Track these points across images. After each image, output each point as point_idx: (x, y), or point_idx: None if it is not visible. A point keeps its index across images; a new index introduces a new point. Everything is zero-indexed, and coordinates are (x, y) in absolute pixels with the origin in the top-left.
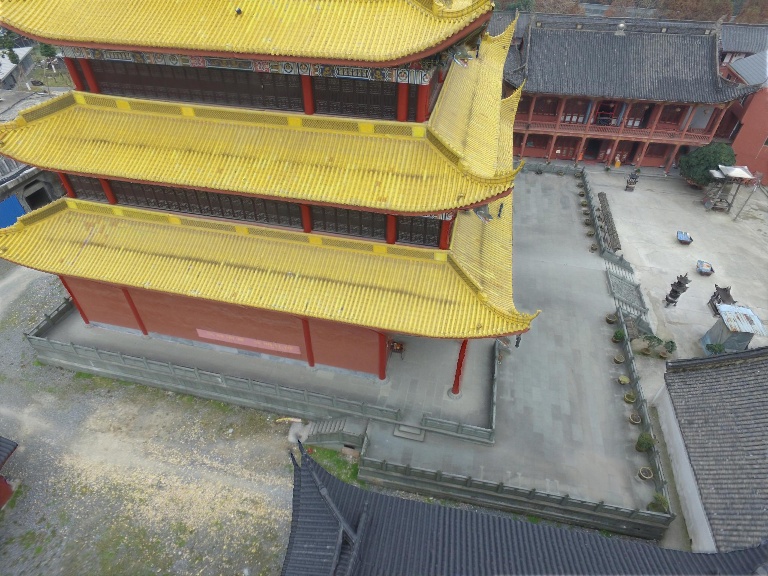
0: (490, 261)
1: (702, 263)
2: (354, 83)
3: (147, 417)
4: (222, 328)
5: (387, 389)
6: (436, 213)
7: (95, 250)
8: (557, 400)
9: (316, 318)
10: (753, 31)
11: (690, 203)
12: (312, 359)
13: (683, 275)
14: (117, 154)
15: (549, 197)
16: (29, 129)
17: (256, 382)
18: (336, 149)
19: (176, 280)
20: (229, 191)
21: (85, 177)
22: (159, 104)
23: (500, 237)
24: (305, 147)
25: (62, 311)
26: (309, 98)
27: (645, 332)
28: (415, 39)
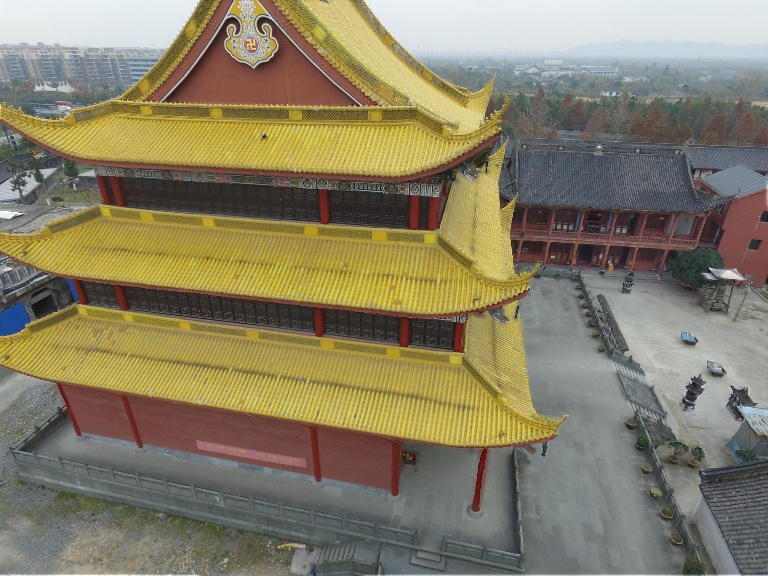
0: (504, 364)
1: (712, 364)
2: (368, 196)
3: (133, 545)
4: (224, 439)
5: (401, 507)
6: (452, 315)
7: (100, 357)
8: (587, 517)
9: (328, 426)
10: (715, 151)
11: (687, 304)
12: (319, 473)
13: (695, 376)
14: (136, 262)
15: (550, 300)
16: (53, 239)
17: (258, 501)
18: (350, 255)
19: (182, 387)
20: (245, 296)
21: (100, 284)
22: (181, 216)
23: (511, 339)
24: (320, 254)
25: (54, 422)
26: (325, 209)
27: (668, 438)
28: (427, 158)
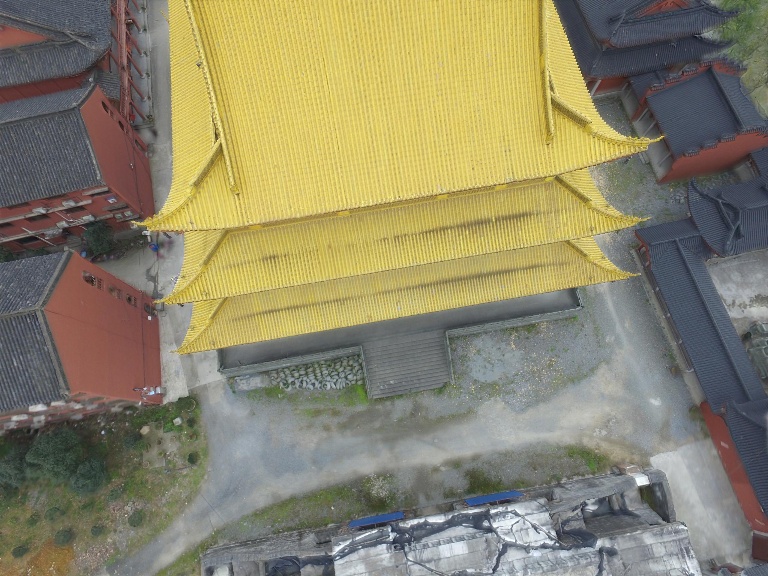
0: None
1: None
2: None
3: None
4: None
5: None
6: None
7: None
8: None
9: None
10: None
11: None
12: None
13: None
14: None
15: None
16: None
17: None
18: None
19: None
20: None
21: None
22: None
23: None
24: None
25: None
26: None
27: None
28: None
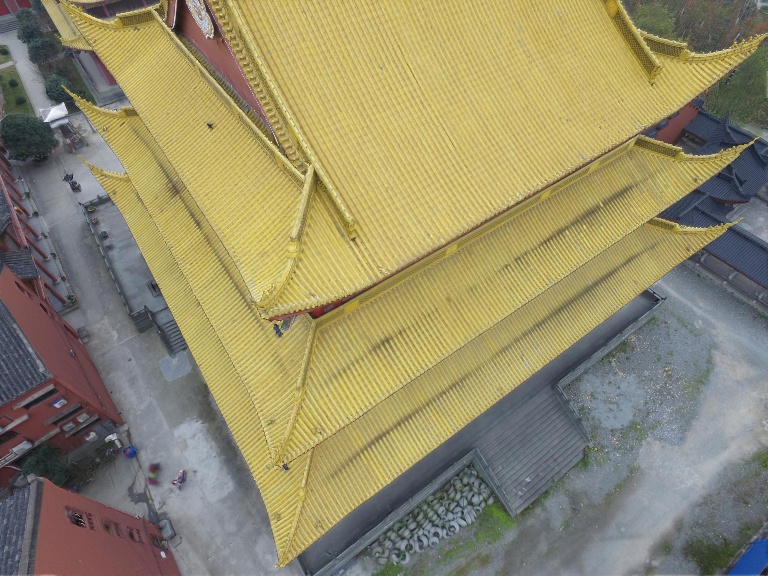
0: None
1: None
2: None
3: None
4: None
5: None
6: None
7: None
8: None
9: None
10: None
11: None
12: None
13: None
14: None
15: None
16: None
17: None
18: None
19: None
20: None
21: None
22: None
23: None
24: None
25: None
26: None
27: None
28: None
